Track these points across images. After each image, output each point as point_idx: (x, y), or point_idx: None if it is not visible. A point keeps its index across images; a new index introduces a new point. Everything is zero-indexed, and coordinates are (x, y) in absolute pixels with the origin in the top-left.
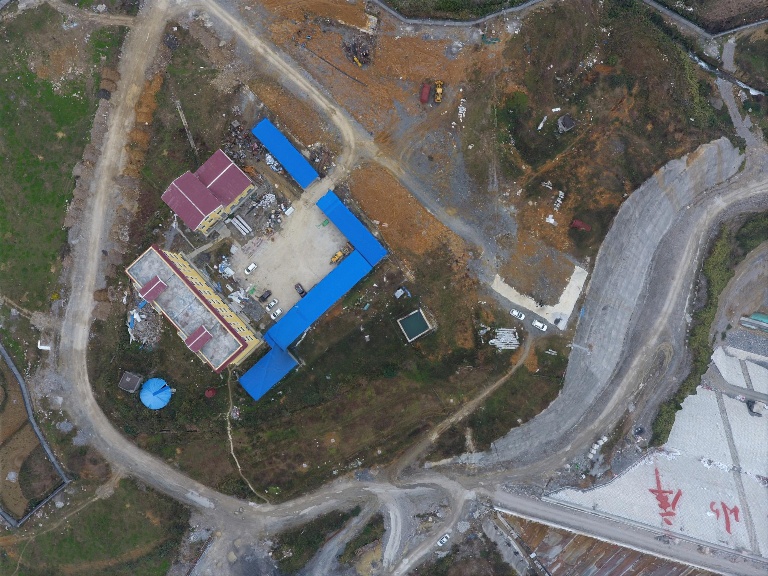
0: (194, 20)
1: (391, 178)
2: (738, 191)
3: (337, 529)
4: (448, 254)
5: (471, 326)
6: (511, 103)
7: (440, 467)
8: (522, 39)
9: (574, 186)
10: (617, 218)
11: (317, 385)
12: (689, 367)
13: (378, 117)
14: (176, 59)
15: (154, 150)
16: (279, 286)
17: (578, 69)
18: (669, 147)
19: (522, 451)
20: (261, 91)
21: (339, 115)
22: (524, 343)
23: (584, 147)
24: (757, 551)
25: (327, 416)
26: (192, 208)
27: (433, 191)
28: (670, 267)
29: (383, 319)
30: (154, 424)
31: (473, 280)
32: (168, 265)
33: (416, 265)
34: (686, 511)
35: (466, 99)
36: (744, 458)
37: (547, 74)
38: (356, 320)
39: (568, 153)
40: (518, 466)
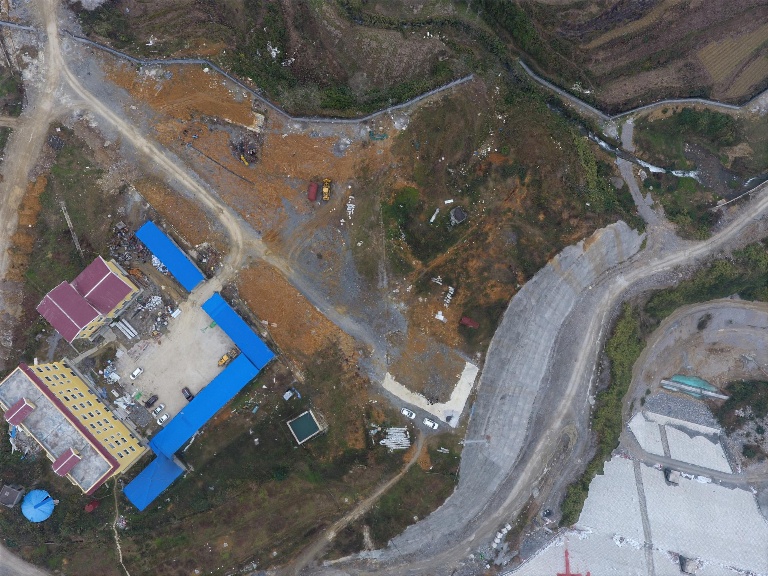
0: (78, 120)
1: (280, 277)
2: (640, 269)
3: None
4: (338, 353)
5: (362, 426)
6: (401, 198)
7: (340, 564)
8: (409, 135)
9: (464, 281)
10: (507, 312)
11: (205, 491)
12: (594, 448)
13: (266, 216)
14: (61, 159)
15: (38, 252)
16: (166, 390)
17: (472, 158)
18: (564, 233)
19: (425, 543)
20: (147, 191)
21: (226, 214)
22: (416, 441)
23: (476, 239)
24: None
25: (218, 521)
26: (67, 320)
27: (322, 289)
28: (573, 349)
29: (272, 421)
30: (37, 537)
31: (363, 379)
32: (36, 385)
33: (305, 365)
34: None
35: (354, 196)
36: (656, 533)
37: (438, 167)
38: (245, 423)
39: (460, 246)
40: (421, 559)
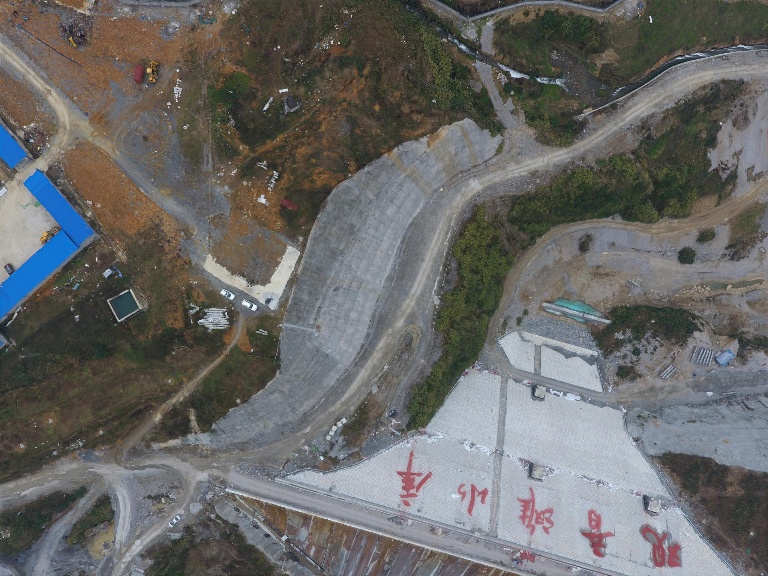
0: None
1: (105, 158)
2: (495, 174)
3: (64, 510)
4: (160, 234)
5: (182, 306)
6: (230, 84)
7: (171, 448)
8: (239, 19)
9: (289, 166)
10: (332, 198)
11: (26, 365)
12: (439, 349)
13: (93, 98)
14: None
15: None
16: None
17: (313, 50)
18: (407, 128)
19: (257, 432)
20: None
21: (54, 96)
22: (236, 323)
23: (309, 128)
24: (494, 532)
25: (42, 396)
26: None
27: (147, 171)
28: (420, 249)
29: (93, 299)
30: None
31: (185, 260)
32: None
33: (127, 245)
34: (430, 493)
35: (182, 79)
36: (510, 441)
37: (273, 55)
38: (67, 300)
39: (291, 134)
40: (254, 448)
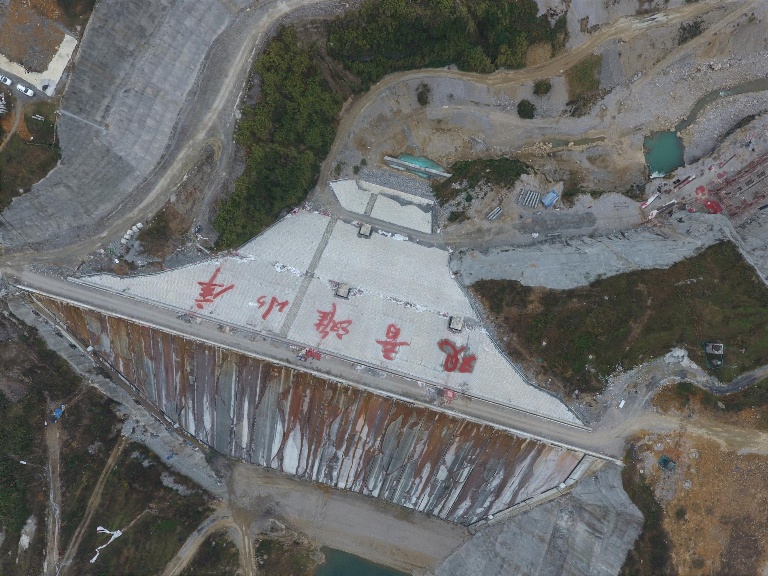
0: None
1: None
2: None
3: None
4: None
5: None
6: None
7: None
8: None
9: None
10: None
11: None
12: (242, 164)
13: None
14: None
15: None
16: None
17: None
18: None
19: (52, 233)
20: None
21: None
22: (14, 109)
23: None
24: (284, 334)
25: None
26: None
27: None
28: (224, 65)
29: None
30: None
31: None
32: None
33: None
34: (227, 300)
35: None
36: (323, 266)
37: None
38: None
39: None
40: (49, 249)
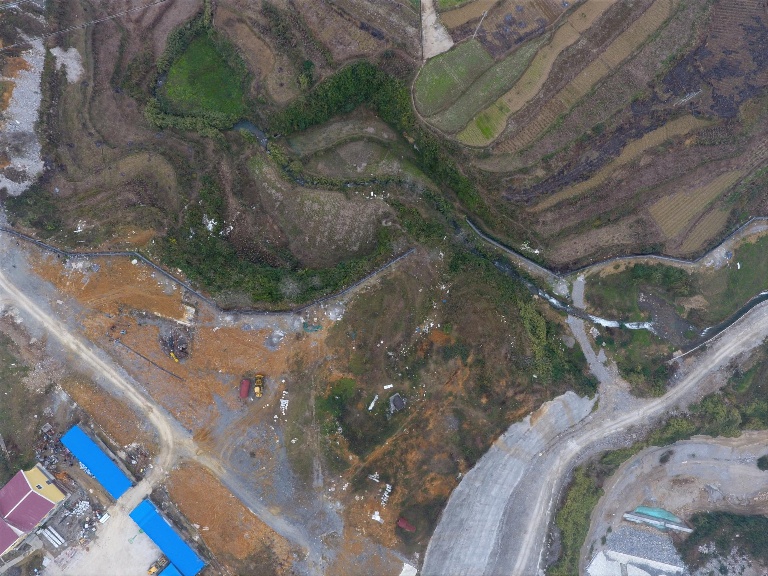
0: (3, 316)
1: (211, 478)
2: (592, 432)
3: None
4: (272, 557)
5: None
6: (337, 390)
7: None
8: (345, 326)
9: (402, 477)
10: (447, 509)
11: None
12: None
13: (197, 414)
14: None
15: None
16: None
17: (414, 336)
18: (510, 410)
19: None
20: (74, 390)
21: (156, 413)
22: None
23: (417, 426)
24: None
25: None
26: None
27: (256, 490)
28: (522, 520)
29: None
30: None
31: None
32: None
33: (238, 571)
34: None
35: (288, 391)
36: None
37: (377, 351)
38: None
39: (399, 435)
40: None
